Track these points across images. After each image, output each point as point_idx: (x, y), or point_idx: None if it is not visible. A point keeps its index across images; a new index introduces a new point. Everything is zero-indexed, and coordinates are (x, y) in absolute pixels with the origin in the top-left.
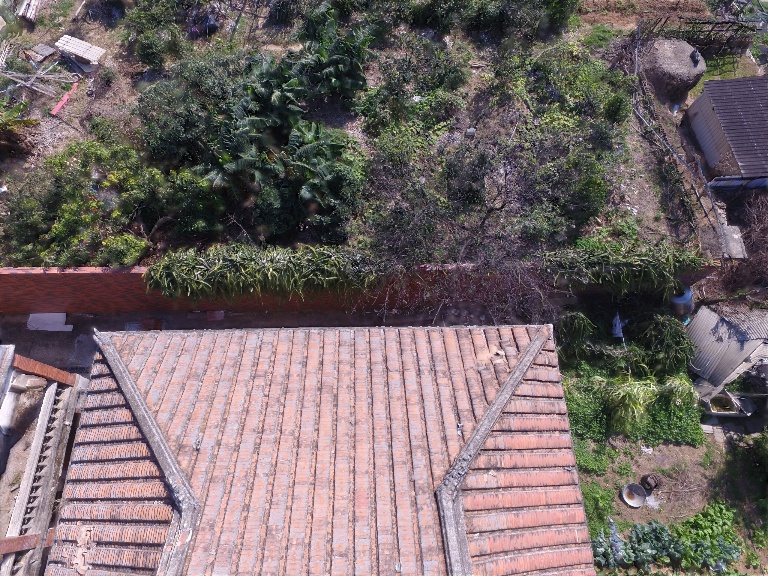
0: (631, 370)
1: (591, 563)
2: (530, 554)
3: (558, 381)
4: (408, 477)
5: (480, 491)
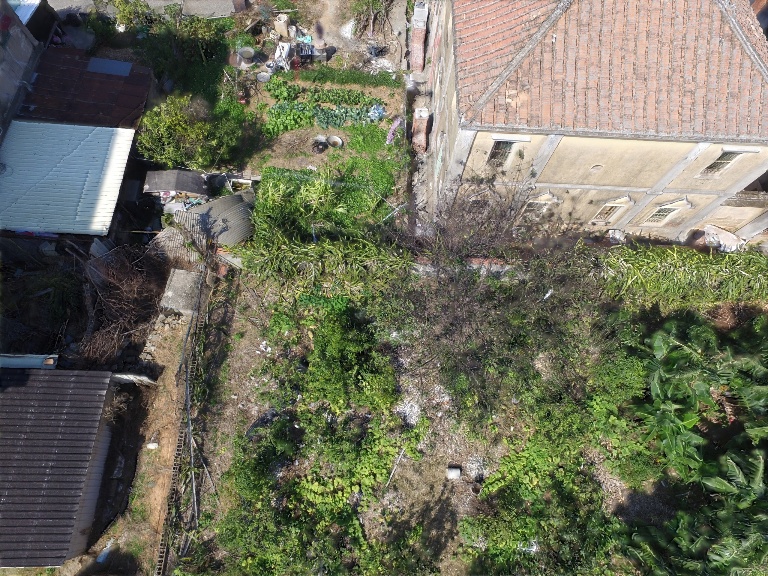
0: None
1: None
2: None
3: None
4: (593, 8)
5: None
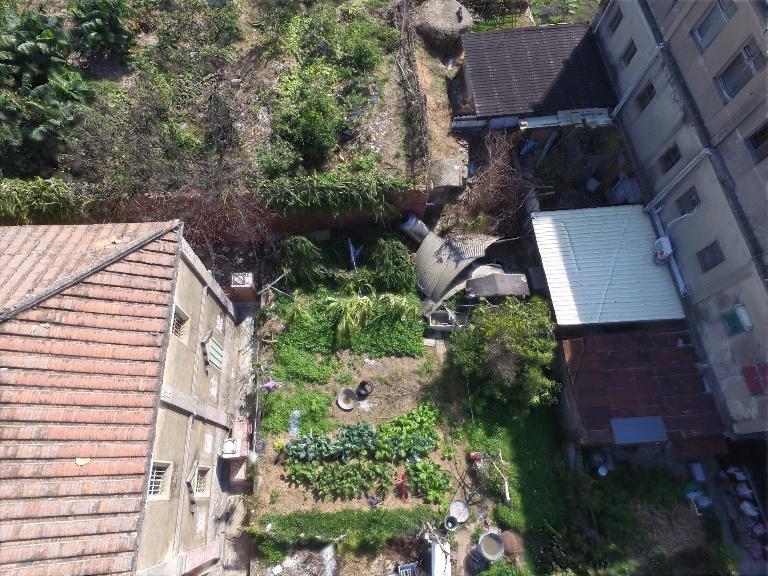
0: (361, 291)
1: (151, 407)
2: (72, 392)
3: (170, 265)
4: None
5: (24, 337)
